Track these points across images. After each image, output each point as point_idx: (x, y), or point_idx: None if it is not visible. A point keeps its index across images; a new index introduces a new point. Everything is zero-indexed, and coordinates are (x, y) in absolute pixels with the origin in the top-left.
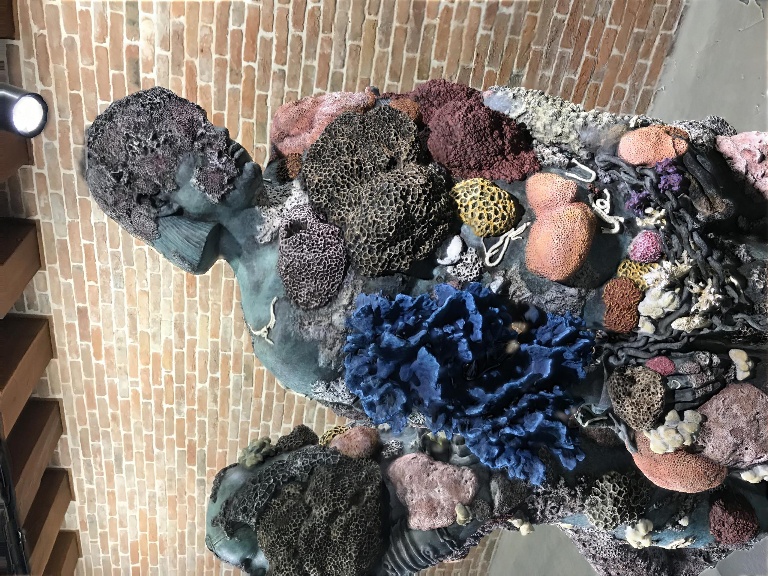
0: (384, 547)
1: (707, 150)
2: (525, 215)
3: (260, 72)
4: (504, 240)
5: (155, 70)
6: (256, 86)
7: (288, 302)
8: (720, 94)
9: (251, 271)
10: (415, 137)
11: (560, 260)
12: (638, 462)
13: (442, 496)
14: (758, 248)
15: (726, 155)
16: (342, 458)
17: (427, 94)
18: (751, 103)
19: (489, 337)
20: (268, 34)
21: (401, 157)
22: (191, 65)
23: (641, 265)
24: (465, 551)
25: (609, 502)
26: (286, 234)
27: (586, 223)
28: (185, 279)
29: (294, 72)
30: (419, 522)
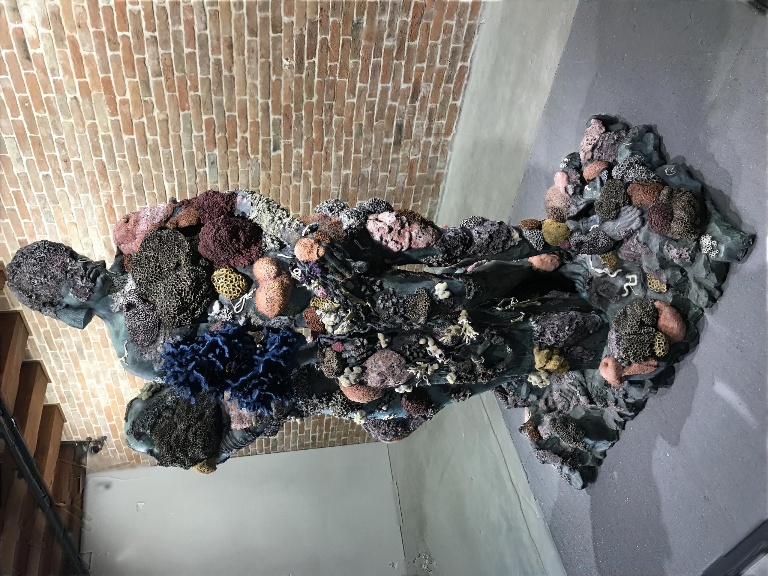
0: (220, 439)
1: (358, 230)
2: (253, 284)
3: (134, 39)
4: (242, 300)
5: (42, 46)
6: (133, 51)
7: (133, 343)
8: (512, 44)
9: (113, 325)
10: (189, 249)
11: (269, 310)
12: (341, 389)
13: (246, 412)
14: (389, 280)
15: (370, 231)
16: None
17: (202, 206)
18: (528, 58)
19: (235, 353)
20: (135, 8)
21: (182, 263)
22: (72, 39)
23: (323, 299)
24: (273, 432)
25: (339, 404)
26: (126, 309)
27: (281, 290)
28: (105, 211)
29: (164, 37)
30: (235, 426)
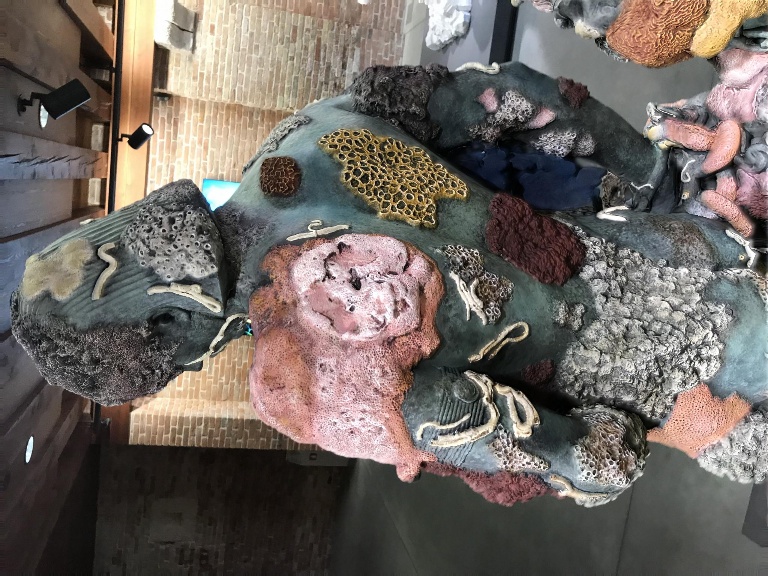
0: None
1: None
2: None
3: None
4: None
5: None
6: None
7: None
8: None
9: None
10: None
11: None
12: None
13: None
14: None
15: None
16: None
17: None
18: None
19: None
20: None
21: None
22: None
23: None
24: None
25: None
26: None
27: None
28: None
29: None
30: None
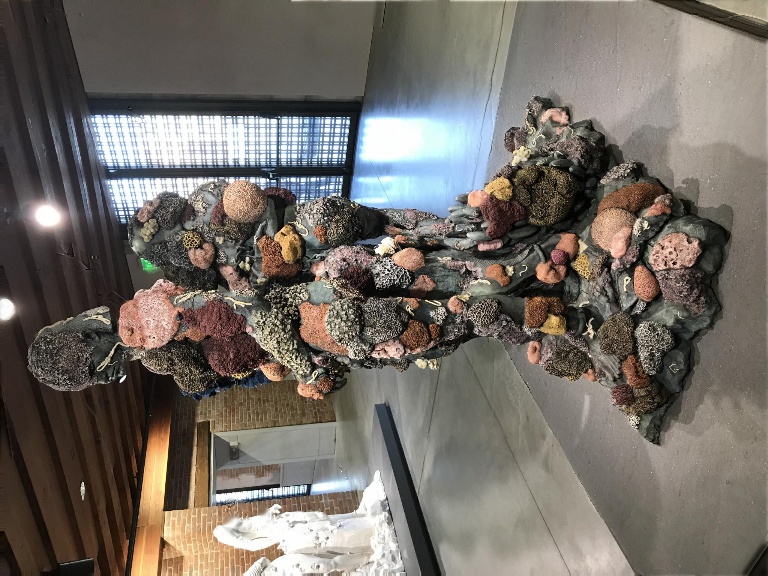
0: None
1: None
2: None
3: None
4: None
5: None
6: None
7: None
8: None
9: None
10: None
11: None
12: None
13: None
14: None
15: None
16: (195, 267)
17: None
18: None
19: None
20: None
21: None
22: None
23: None
24: None
25: None
26: None
27: None
28: None
29: None
30: None
